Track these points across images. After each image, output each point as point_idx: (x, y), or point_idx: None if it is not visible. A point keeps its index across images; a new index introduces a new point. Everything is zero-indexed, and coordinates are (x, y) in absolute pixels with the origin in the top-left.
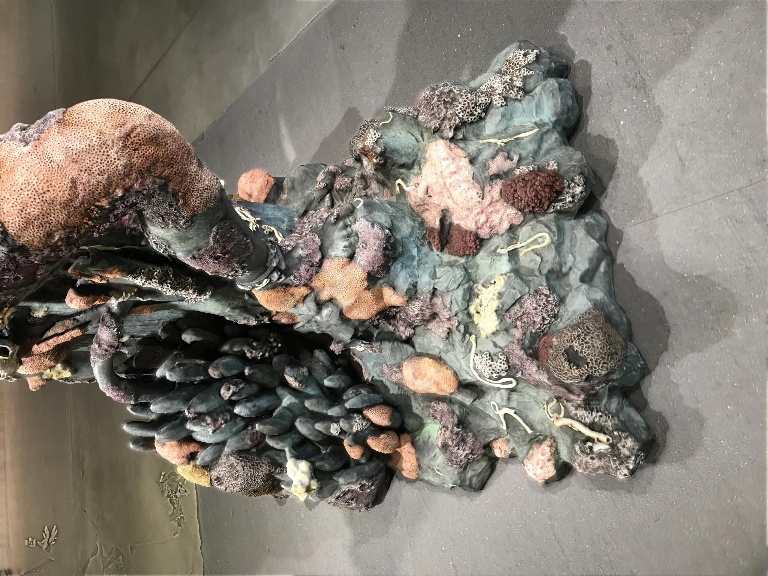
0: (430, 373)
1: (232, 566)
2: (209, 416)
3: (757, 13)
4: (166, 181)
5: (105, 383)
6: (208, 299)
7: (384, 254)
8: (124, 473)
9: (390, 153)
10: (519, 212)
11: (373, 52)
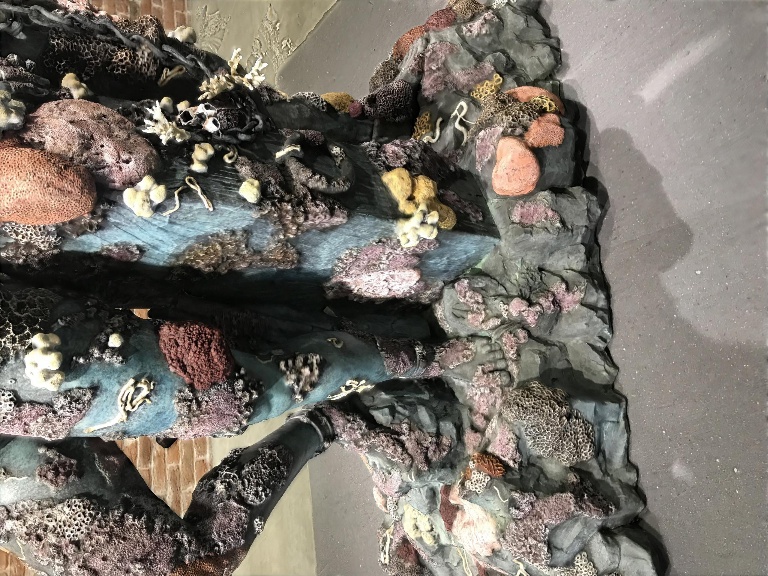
0: None
1: None
2: None
3: None
4: None
5: None
6: None
7: None
8: None
9: None
10: (476, 566)
11: (767, 290)
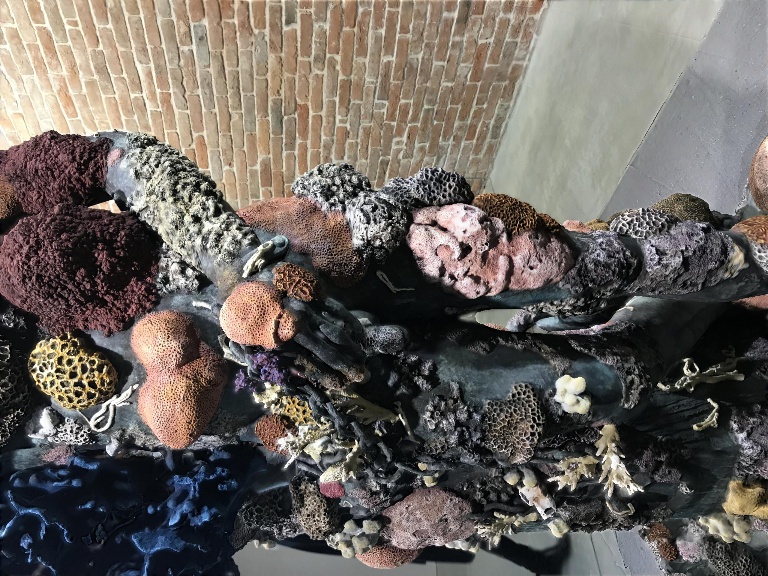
0: None
1: None
2: None
3: None
4: None
5: None
6: None
7: None
8: None
9: None
10: None
11: None
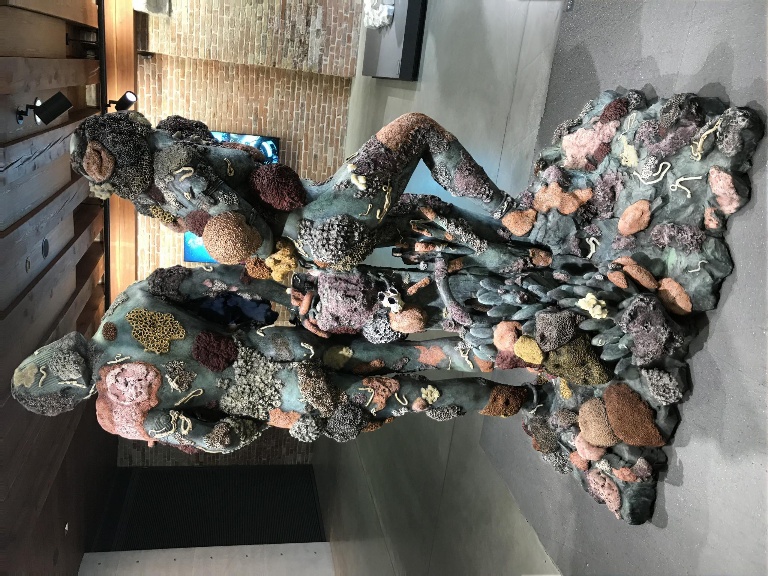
0: (629, 209)
1: None
2: None
3: (649, 3)
4: (433, 126)
5: (449, 299)
6: (487, 248)
7: (560, 170)
8: None
9: (546, 158)
10: (615, 121)
11: None
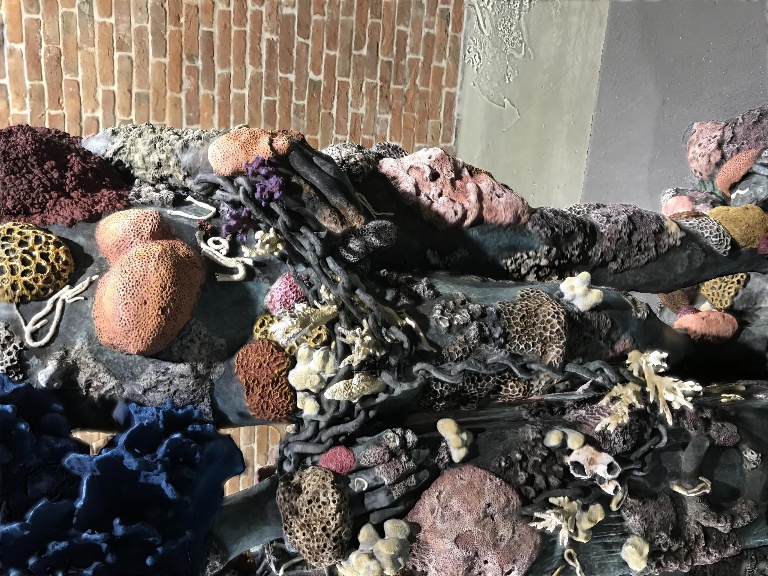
0: None
1: (664, 2)
2: None
3: None
4: None
5: None
6: None
7: None
8: None
9: None
10: None
11: None
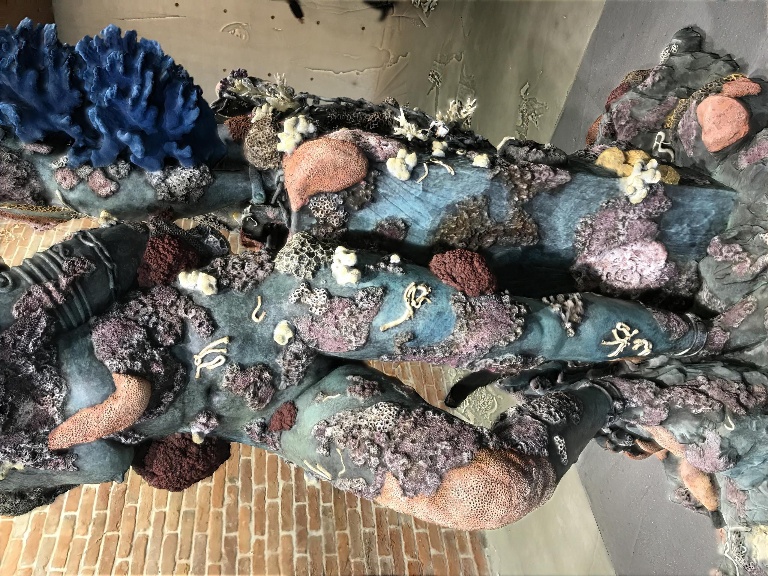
0: (700, 491)
1: None
2: (514, 389)
3: None
4: None
5: None
6: None
7: None
8: (502, 29)
9: None
10: None
11: None
